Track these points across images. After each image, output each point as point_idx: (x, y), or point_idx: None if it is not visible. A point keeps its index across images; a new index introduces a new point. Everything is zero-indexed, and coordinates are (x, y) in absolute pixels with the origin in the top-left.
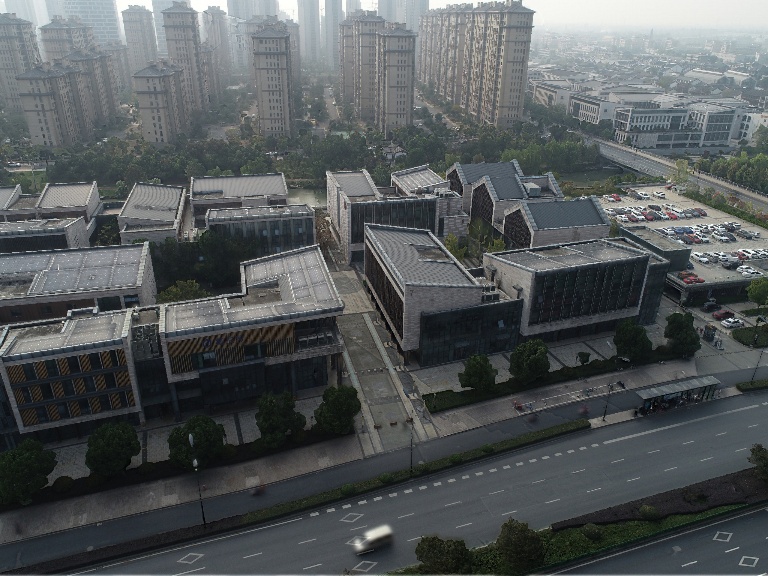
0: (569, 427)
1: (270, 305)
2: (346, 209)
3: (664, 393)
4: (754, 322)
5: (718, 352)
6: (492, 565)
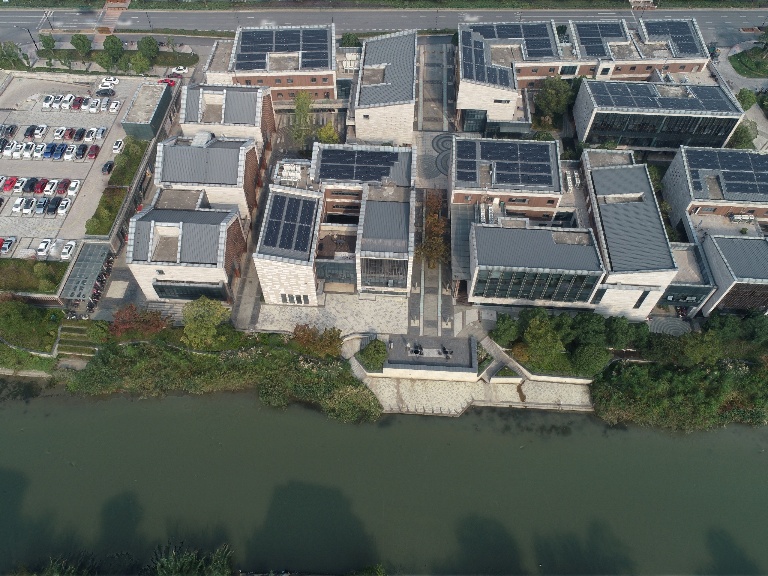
0: (354, 34)
1: (498, 40)
2: None
3: None
4: (162, 71)
5: None
6: (422, 3)
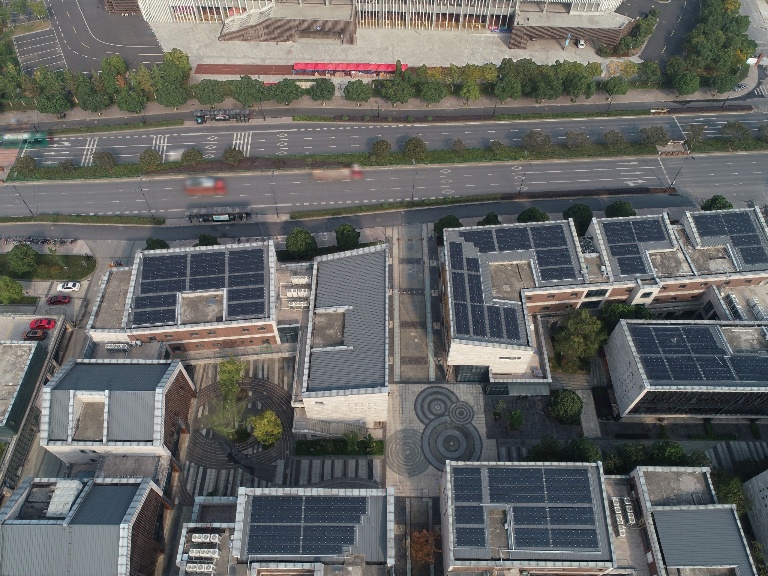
0: (306, 213)
1: (499, 255)
2: None
3: (234, 207)
4: (44, 289)
5: (128, 260)
6: None
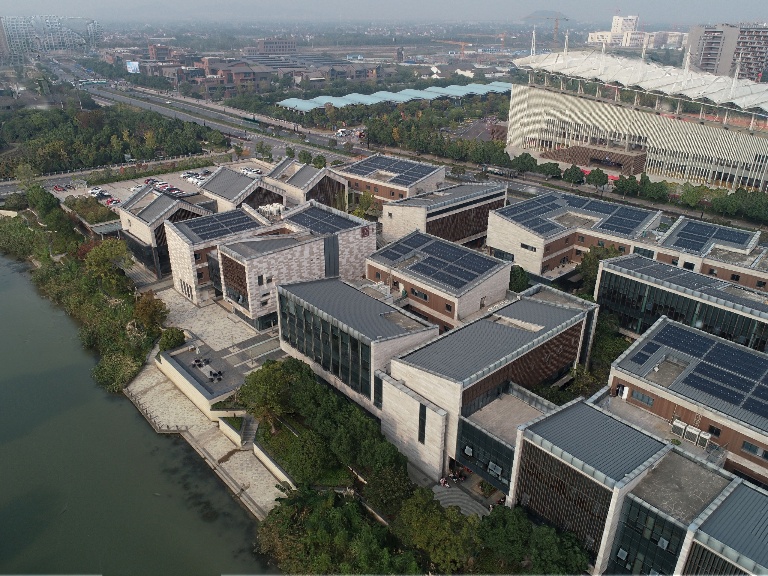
0: None
1: (580, 210)
2: (373, 232)
3: None
4: None
5: None
6: None
